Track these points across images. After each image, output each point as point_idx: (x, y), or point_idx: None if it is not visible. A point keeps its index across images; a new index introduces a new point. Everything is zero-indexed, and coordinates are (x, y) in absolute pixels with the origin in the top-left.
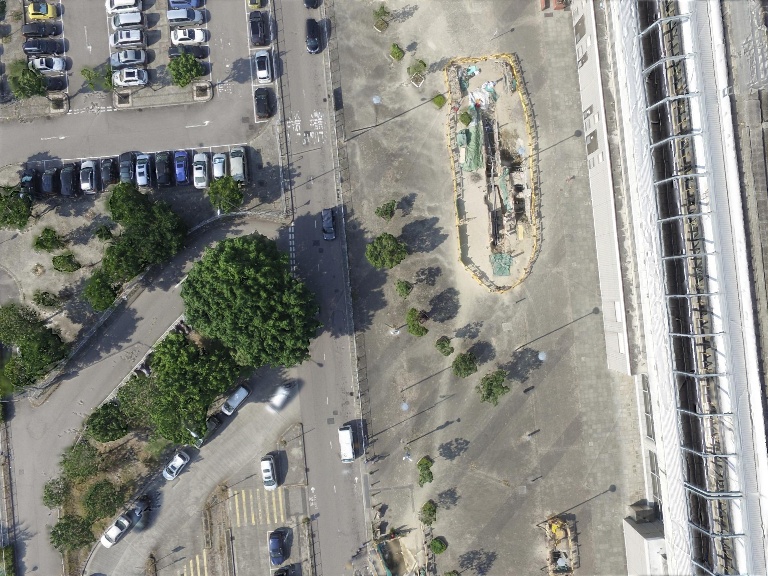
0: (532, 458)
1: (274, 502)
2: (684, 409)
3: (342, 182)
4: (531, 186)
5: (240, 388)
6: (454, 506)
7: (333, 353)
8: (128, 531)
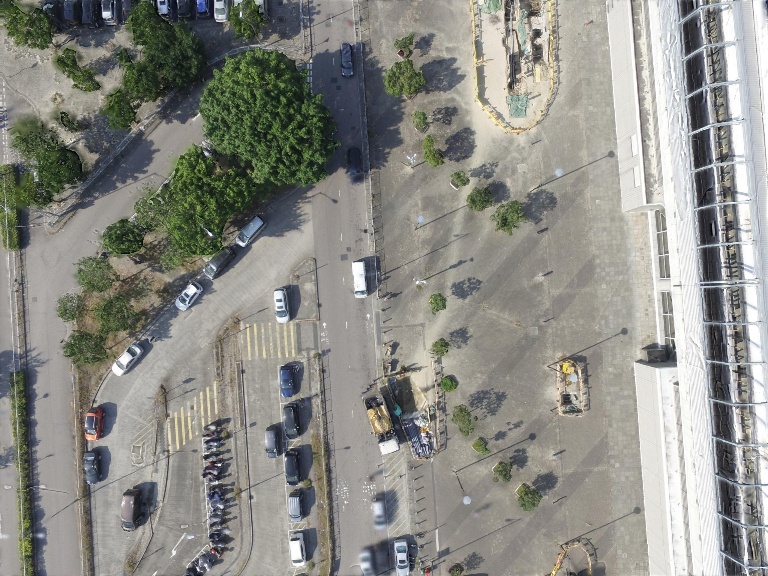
0: (544, 299)
1: (286, 336)
2: (700, 229)
3: (361, 21)
4: (549, 29)
5: (255, 217)
6: (465, 345)
7: (348, 190)
8: (139, 361)
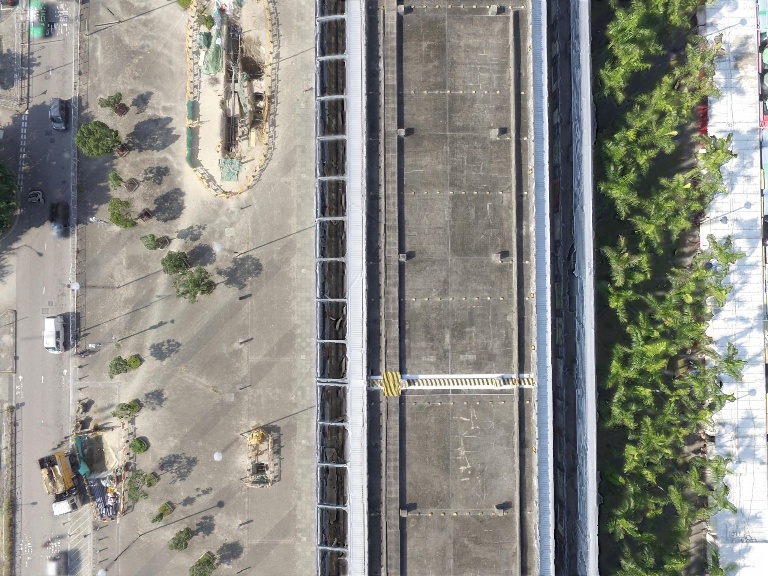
0: (243, 366)
1: None
2: None
3: (80, 75)
4: (267, 94)
5: None
6: (160, 407)
7: (54, 243)
8: None
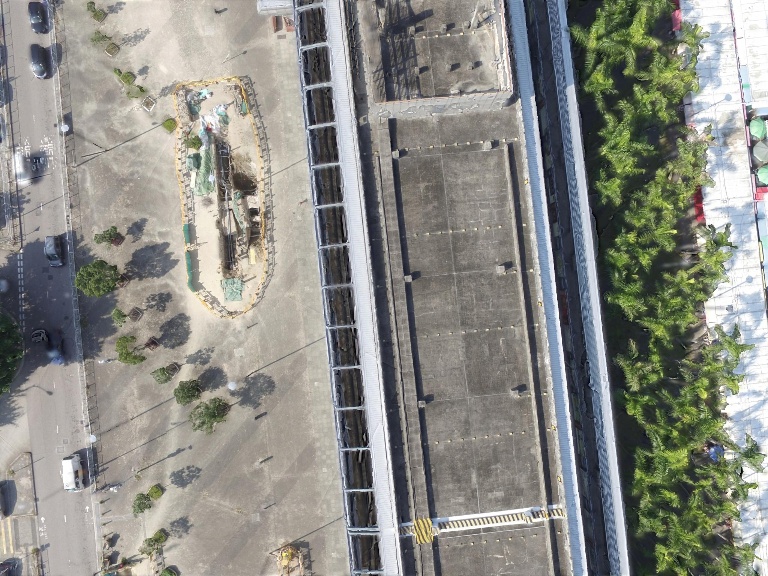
0: (265, 485)
1: (3, 533)
2: None
3: (72, 208)
4: (262, 210)
5: None
6: (186, 535)
7: (63, 381)
8: None
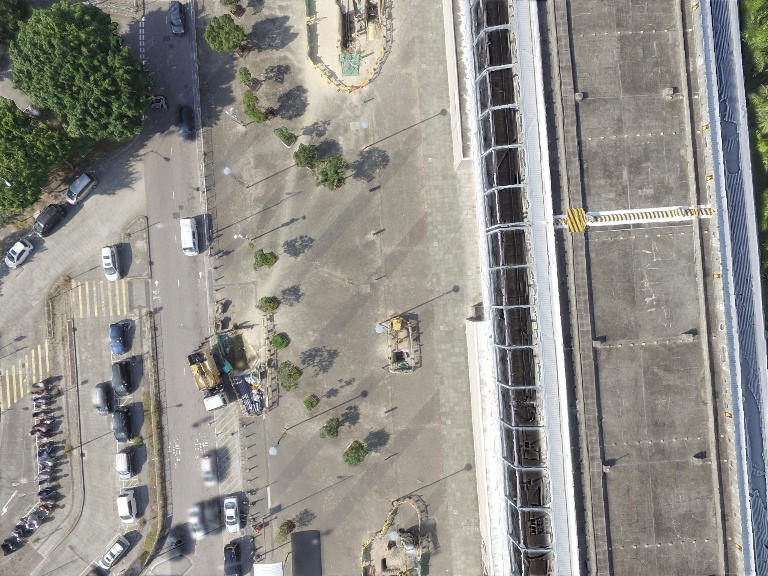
0: (377, 257)
1: (117, 294)
2: (506, 180)
3: None
4: None
5: (82, 174)
6: (297, 303)
7: (180, 148)
8: None
